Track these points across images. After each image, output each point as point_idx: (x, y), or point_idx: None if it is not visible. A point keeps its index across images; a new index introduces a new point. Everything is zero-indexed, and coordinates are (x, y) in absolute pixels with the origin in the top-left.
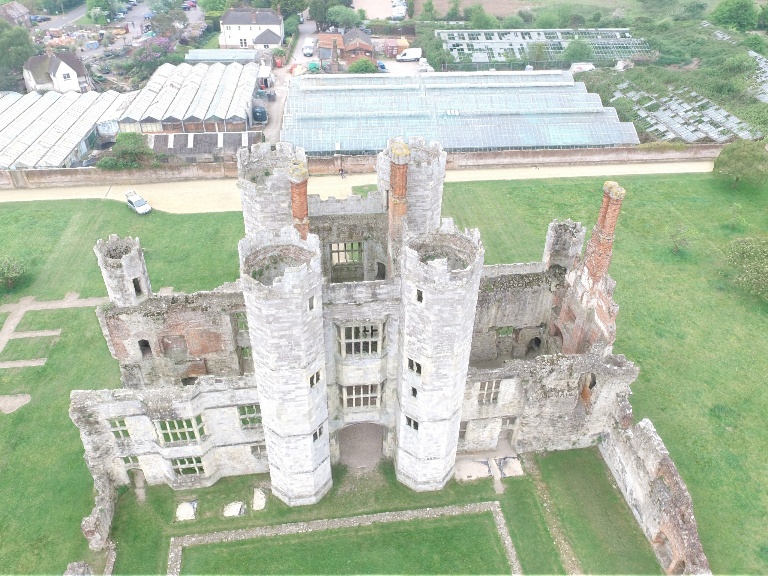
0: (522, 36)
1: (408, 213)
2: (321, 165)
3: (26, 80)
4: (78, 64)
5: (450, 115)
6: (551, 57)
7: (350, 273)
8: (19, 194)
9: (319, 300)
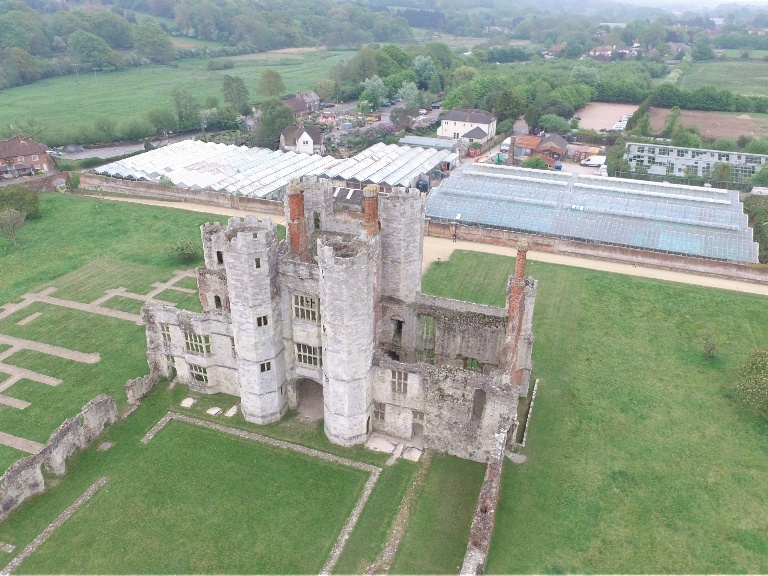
0: (719, 157)
1: (387, 240)
2: (439, 228)
3: (281, 142)
4: (318, 135)
5: (574, 209)
6: (737, 179)
7: None
8: (231, 211)
9: (265, 263)
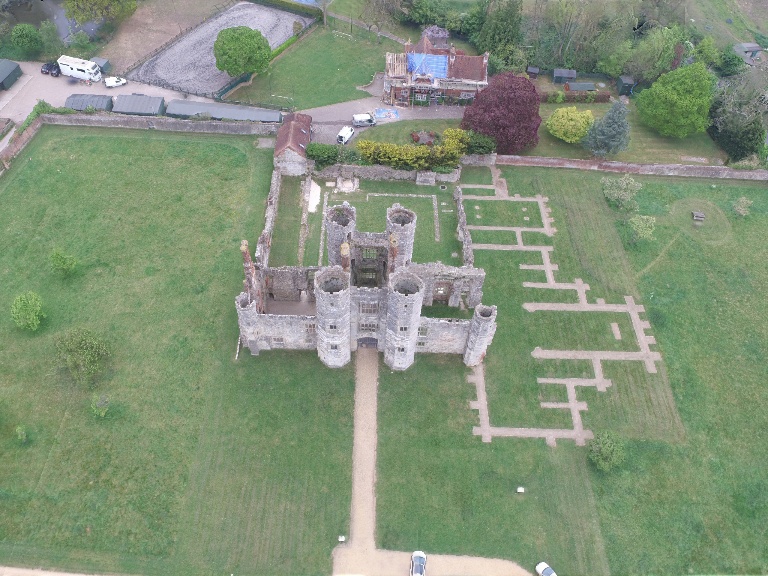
0: None
1: None
2: None
3: None
4: None
5: None
6: None
7: None
8: None
9: None
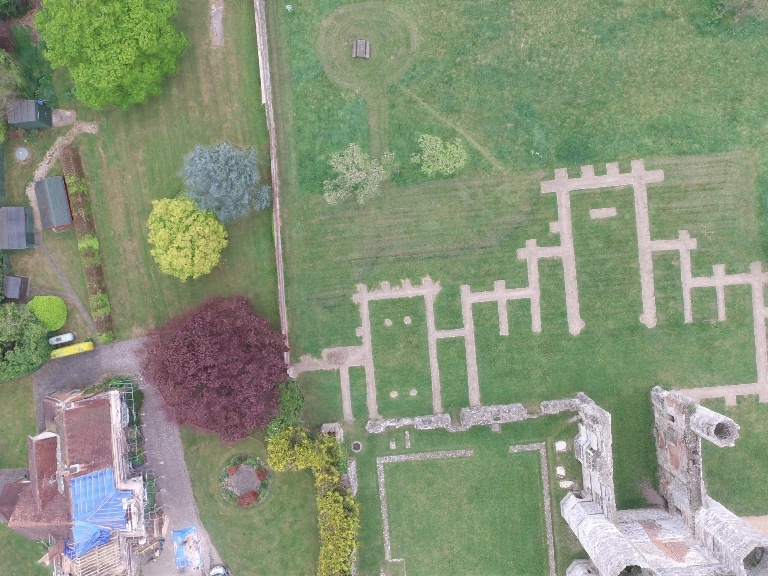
0: None
1: None
2: None
3: None
4: None
5: None
6: None
7: None
8: None
9: None
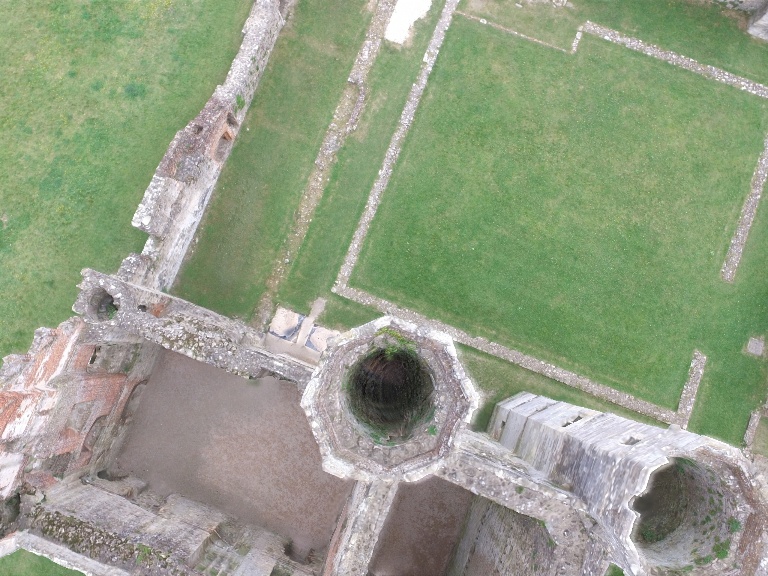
0: None
1: None
2: None
3: None
4: None
5: None
6: None
7: None
8: None
9: None
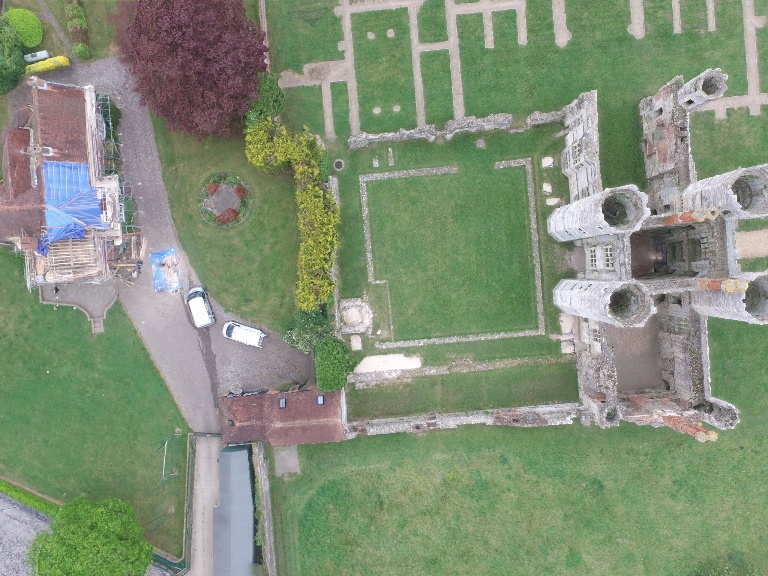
0: None
1: None
2: None
3: None
4: None
5: None
6: None
7: (699, 252)
8: None
9: None
